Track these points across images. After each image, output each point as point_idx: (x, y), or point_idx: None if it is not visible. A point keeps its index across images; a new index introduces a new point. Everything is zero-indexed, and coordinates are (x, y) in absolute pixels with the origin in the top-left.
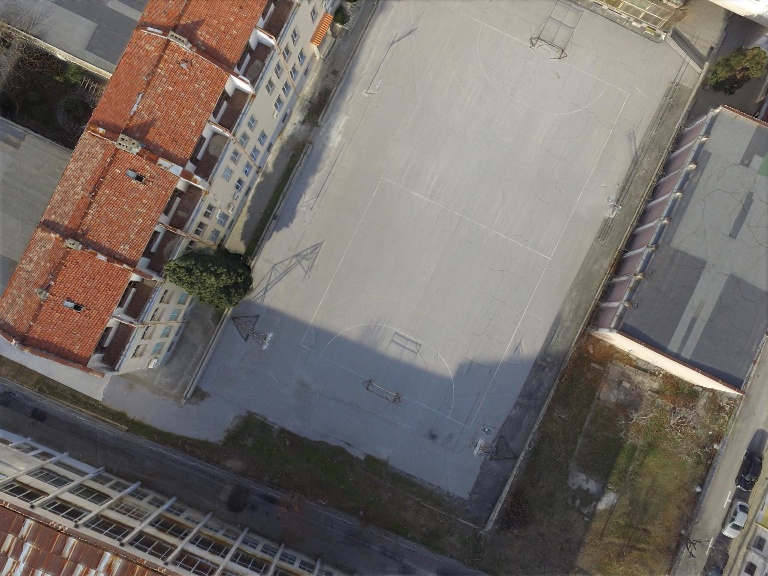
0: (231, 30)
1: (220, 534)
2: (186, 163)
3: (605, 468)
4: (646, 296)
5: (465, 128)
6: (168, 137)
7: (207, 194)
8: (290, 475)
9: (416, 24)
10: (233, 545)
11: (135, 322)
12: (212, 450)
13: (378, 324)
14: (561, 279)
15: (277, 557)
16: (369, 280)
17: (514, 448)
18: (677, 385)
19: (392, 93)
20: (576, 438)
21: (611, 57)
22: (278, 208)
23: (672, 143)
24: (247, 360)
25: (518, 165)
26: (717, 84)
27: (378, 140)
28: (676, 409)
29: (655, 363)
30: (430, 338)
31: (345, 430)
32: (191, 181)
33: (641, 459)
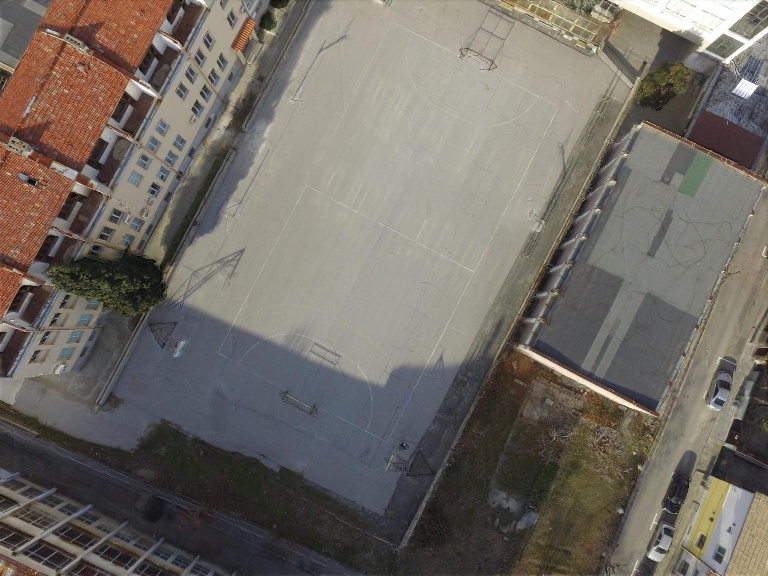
0: (132, 34)
1: (131, 544)
2: (82, 167)
3: (526, 487)
4: (561, 313)
5: (391, 138)
6: (63, 141)
7: (109, 199)
8: (203, 486)
9: (345, 32)
10: (141, 556)
11: (28, 328)
12: (124, 458)
13: (297, 334)
14: (485, 293)
15: (187, 570)
16: (289, 289)
17: (432, 464)
18: (602, 404)
19: (319, 100)
20: (497, 455)
21: (541, 69)
22: (199, 214)
23: (601, 158)
24: (163, 367)
25: (444, 176)
26: (643, 99)
27: (303, 148)
28: (600, 428)
29: (579, 381)
30: (349, 350)
31: (260, 441)
32: (87, 186)
33: (563, 479)
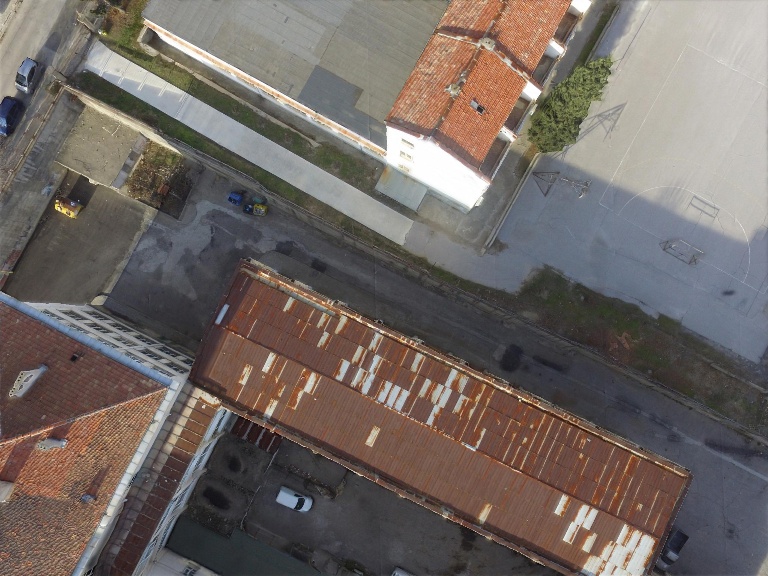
0: None
1: None
2: None
3: None
4: None
5: None
6: None
7: None
8: (584, 330)
9: None
10: None
11: None
12: (509, 300)
13: (677, 187)
14: None
15: None
16: (670, 143)
17: None
18: None
19: None
20: None
21: None
22: None
23: None
24: (546, 215)
25: None
26: None
27: (684, 7)
28: None
29: None
30: (728, 203)
31: (640, 289)
32: None
33: None
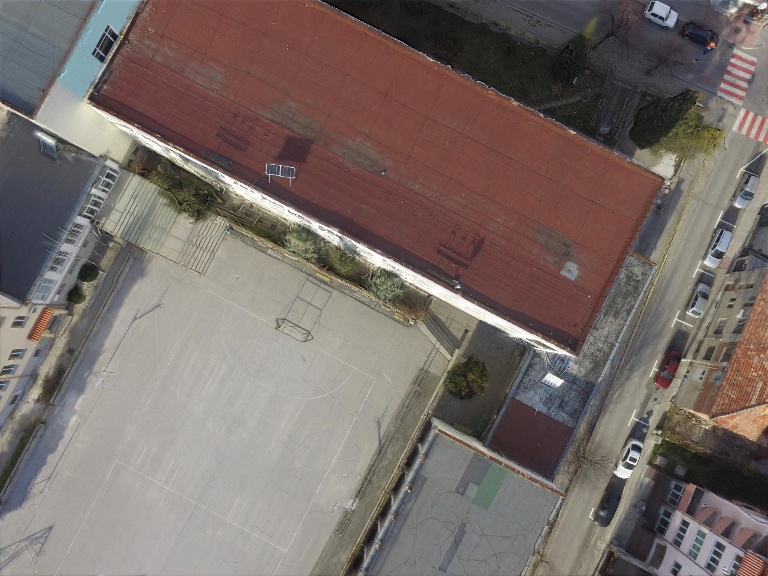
0: None
1: None
2: None
3: None
4: None
5: (205, 411)
6: None
7: None
8: None
9: (159, 301)
10: None
11: None
12: None
13: None
14: (296, 573)
15: None
16: (98, 568)
17: None
18: None
19: (131, 372)
20: None
21: (359, 341)
22: (4, 493)
23: (416, 434)
24: None
25: (258, 452)
26: (450, 390)
27: (114, 421)
28: None
29: None
30: None
31: None
32: None
33: None
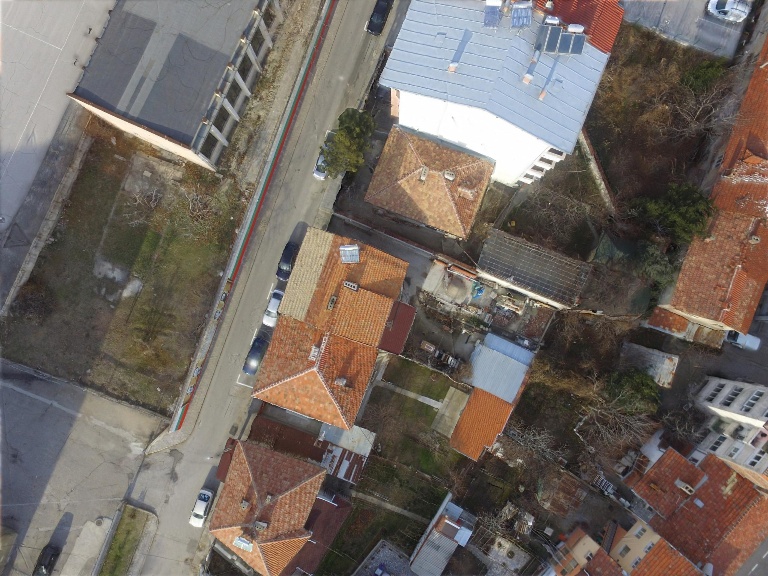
0: None
1: None
2: None
3: (130, 257)
4: (99, 59)
5: None
6: None
7: None
8: None
9: None
10: None
11: None
12: None
13: None
14: (72, 69)
15: None
16: None
17: (29, 235)
18: (200, 174)
19: None
20: (102, 229)
21: None
22: None
23: None
24: None
25: None
26: None
27: None
28: (198, 197)
29: (169, 149)
30: None
31: None
32: None
33: (165, 247)
